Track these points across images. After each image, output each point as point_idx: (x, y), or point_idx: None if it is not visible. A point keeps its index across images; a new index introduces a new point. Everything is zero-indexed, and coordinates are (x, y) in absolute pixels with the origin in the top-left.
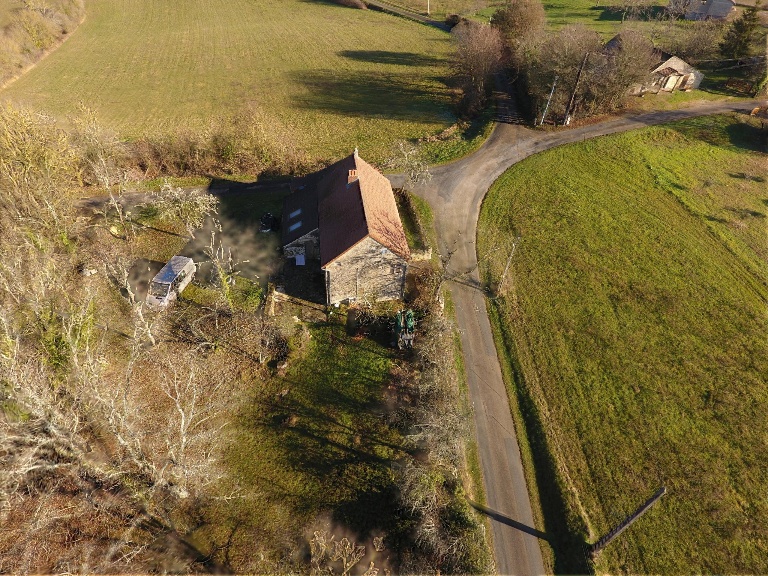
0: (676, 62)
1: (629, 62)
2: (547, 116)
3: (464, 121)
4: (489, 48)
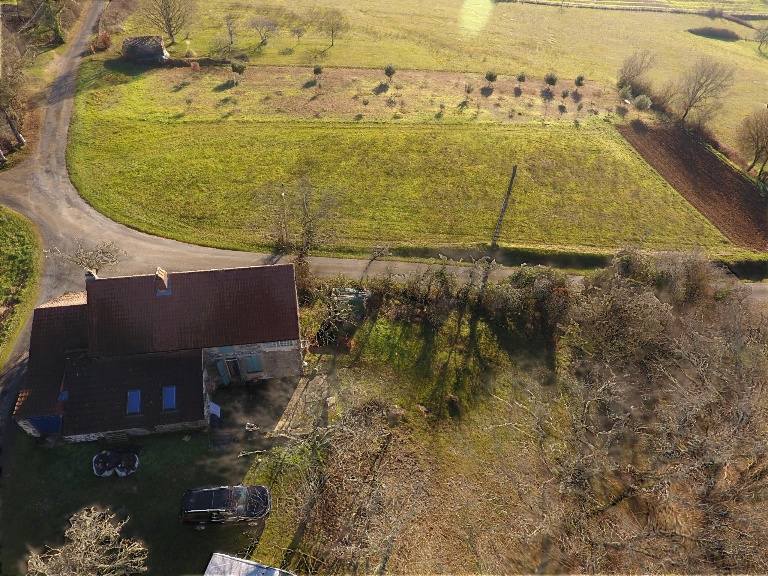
0: None
1: None
2: None
3: None
4: None
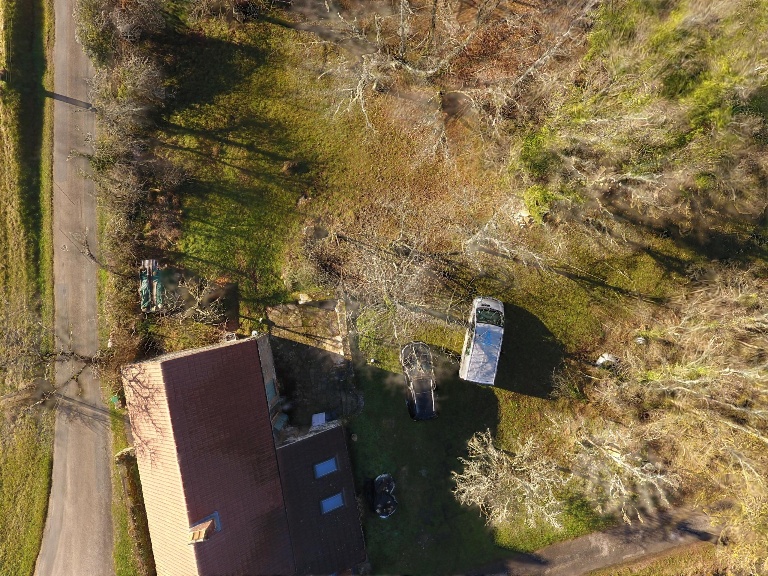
0: None
1: None
2: None
3: None
4: None
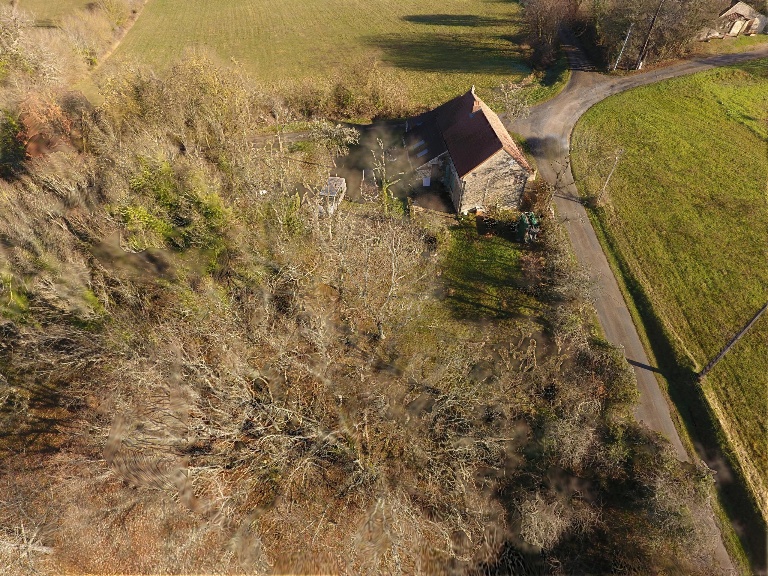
0: (742, 7)
1: (700, 7)
2: (620, 62)
3: (539, 71)
4: (561, 2)
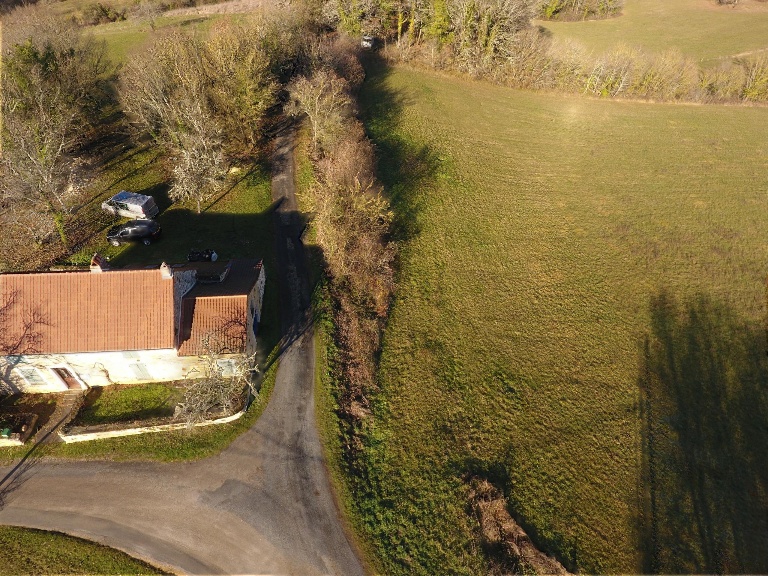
0: None
1: None
2: None
3: None
4: None
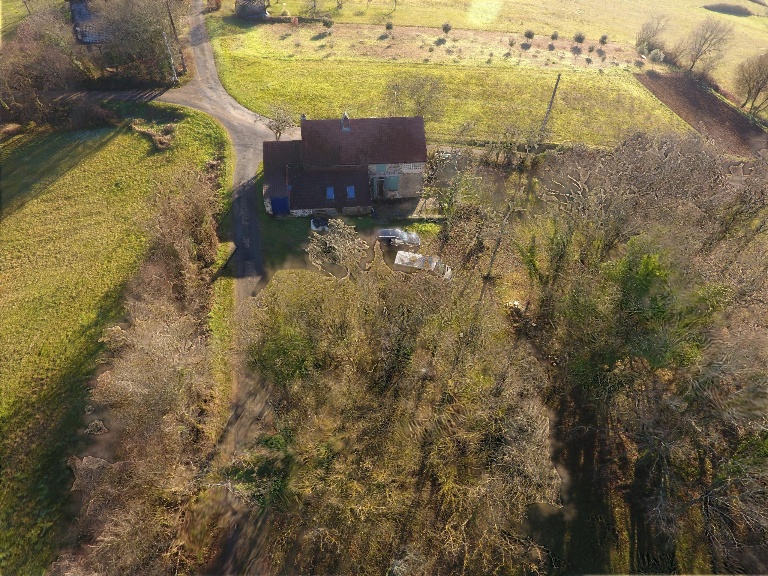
0: None
1: None
2: None
3: (122, 122)
4: (35, 53)
